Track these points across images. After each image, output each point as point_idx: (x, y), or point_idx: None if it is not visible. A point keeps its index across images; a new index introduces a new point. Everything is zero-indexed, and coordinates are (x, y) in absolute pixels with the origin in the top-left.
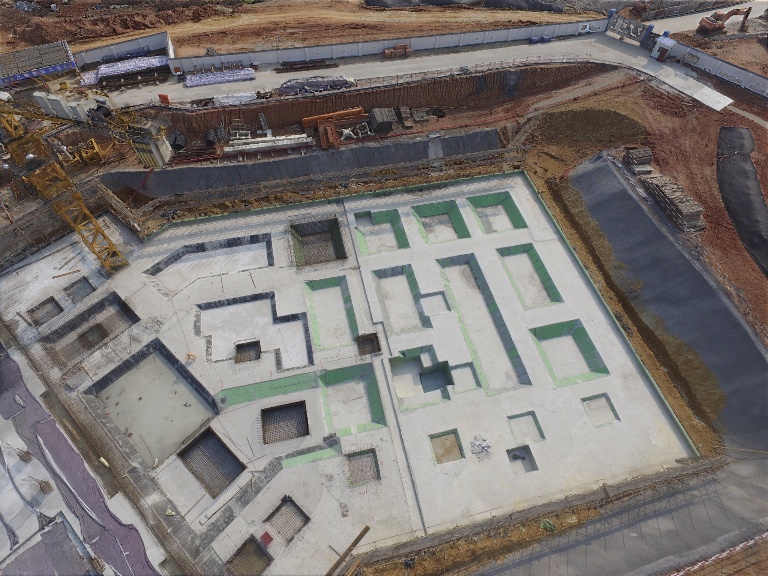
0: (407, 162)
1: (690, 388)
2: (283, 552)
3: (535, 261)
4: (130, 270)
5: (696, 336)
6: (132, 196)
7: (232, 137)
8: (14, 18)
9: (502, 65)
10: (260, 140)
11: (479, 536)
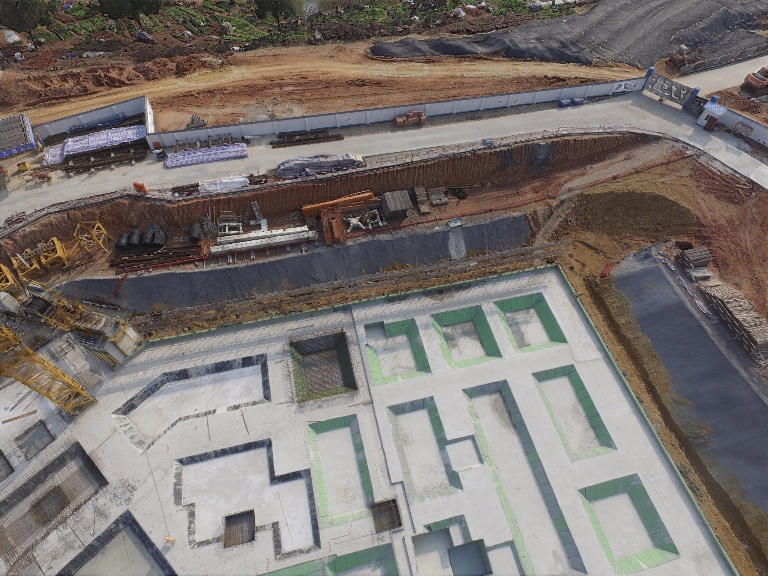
0: (426, 265)
1: None
2: None
3: (578, 388)
4: (97, 410)
5: None
6: None
7: (220, 232)
8: None
9: (530, 136)
10: (253, 236)
11: None
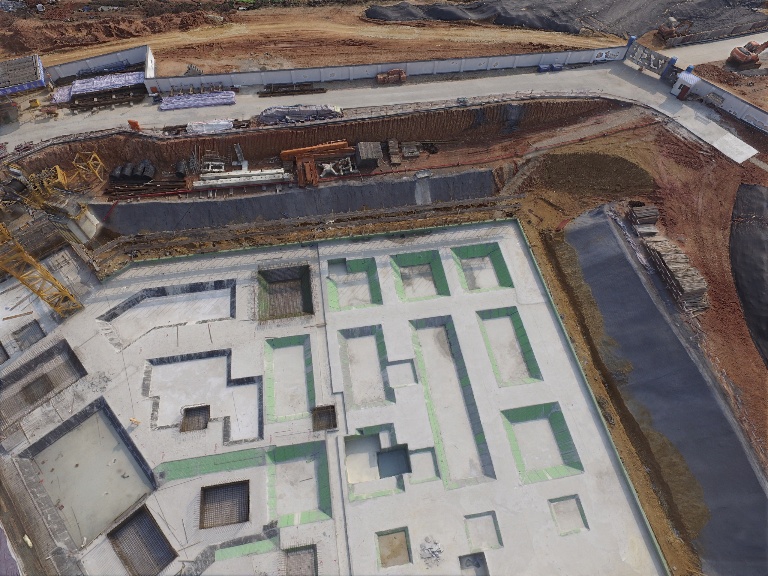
0: (387, 208)
1: (672, 496)
2: None
3: (517, 327)
4: (84, 315)
5: (684, 437)
6: None
7: (204, 170)
8: None
9: (504, 97)
10: (233, 174)
11: None
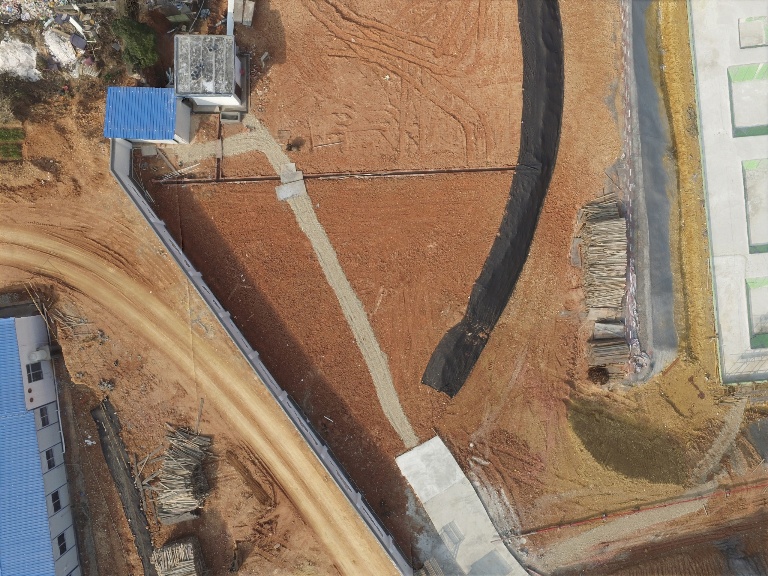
0: None
1: None
2: None
3: None
4: None
5: None
6: None
7: None
8: None
9: None
10: None
11: None
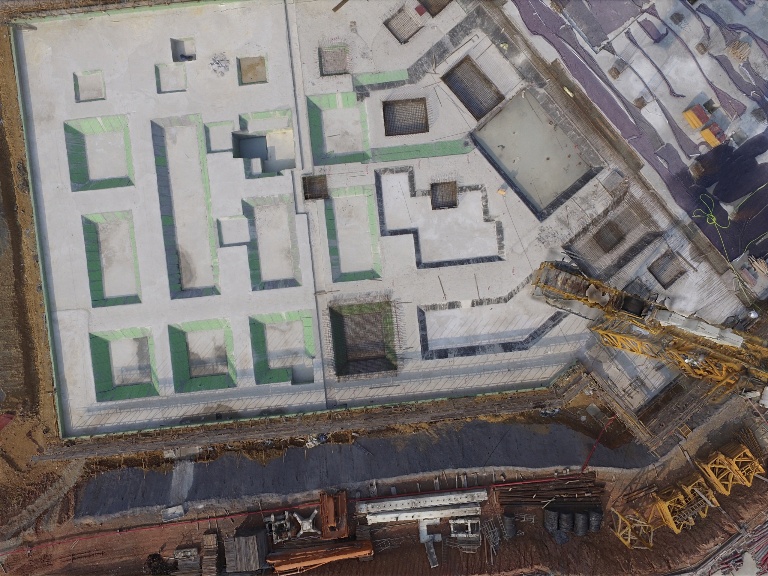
0: None
1: None
2: (407, 0)
3: (98, 282)
4: None
5: None
6: None
7: None
8: None
9: None
10: (436, 512)
11: None
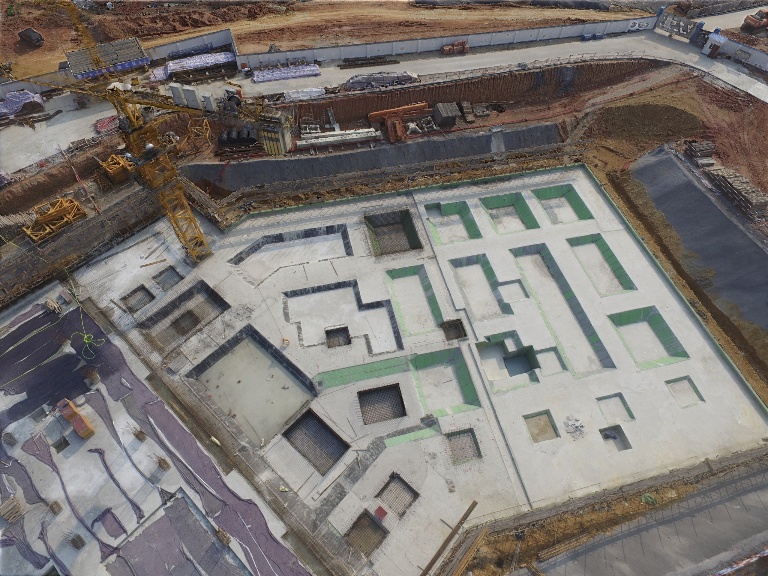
0: (476, 155)
1: None
2: (398, 525)
3: (604, 251)
4: (214, 259)
5: None
6: (208, 188)
7: (303, 131)
8: (74, 16)
9: (558, 61)
10: (331, 134)
11: (584, 510)
